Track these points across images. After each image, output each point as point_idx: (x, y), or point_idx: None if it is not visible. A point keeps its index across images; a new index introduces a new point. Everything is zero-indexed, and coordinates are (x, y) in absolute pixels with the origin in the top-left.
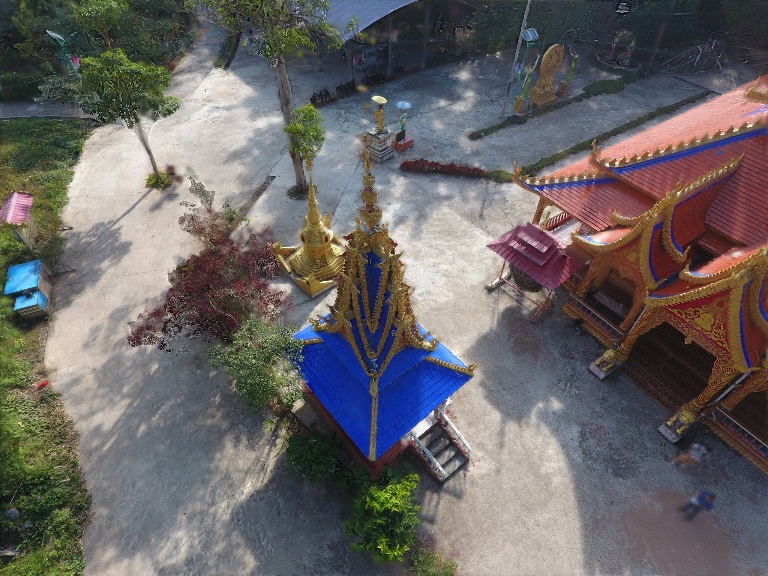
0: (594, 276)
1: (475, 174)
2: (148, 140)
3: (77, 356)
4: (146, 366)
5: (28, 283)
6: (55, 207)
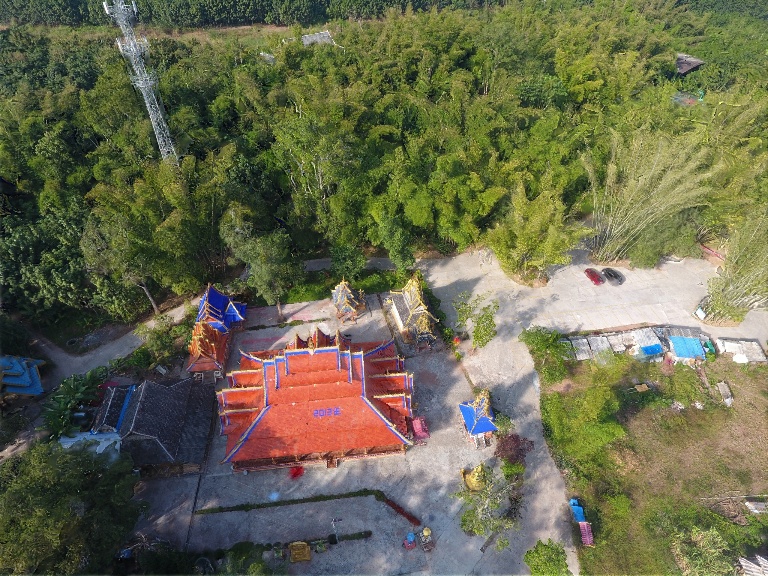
0: None
1: None
2: None
3: (555, 479)
4: (534, 466)
5: (576, 509)
6: (583, 570)
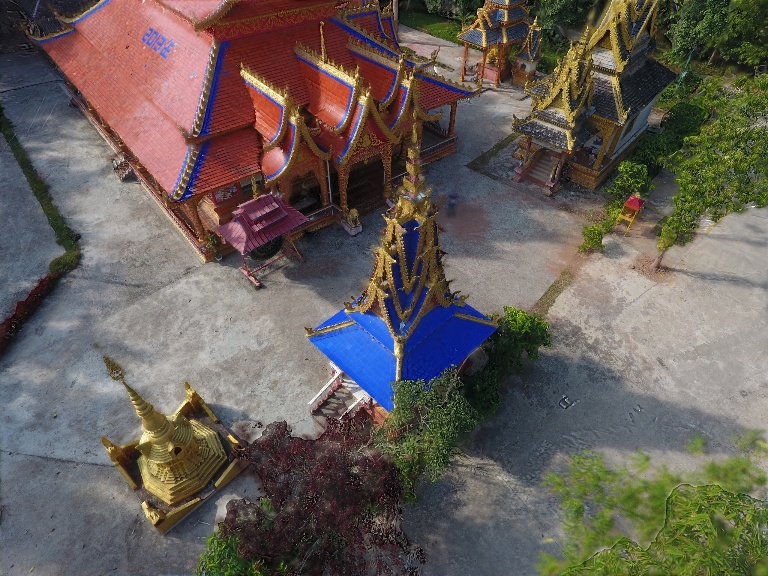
0: (288, 197)
1: (50, 285)
2: None
3: None
4: None
5: None
6: None
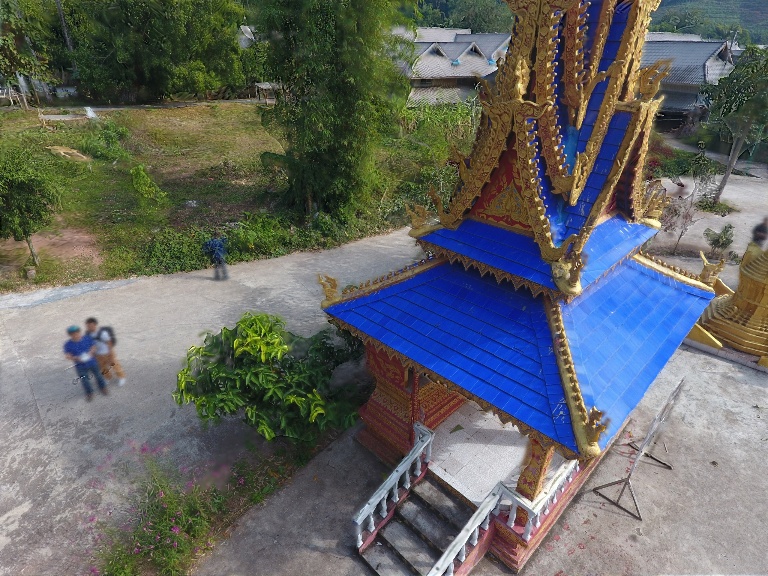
0: None
1: None
2: (765, 194)
3: None
4: None
5: None
6: None
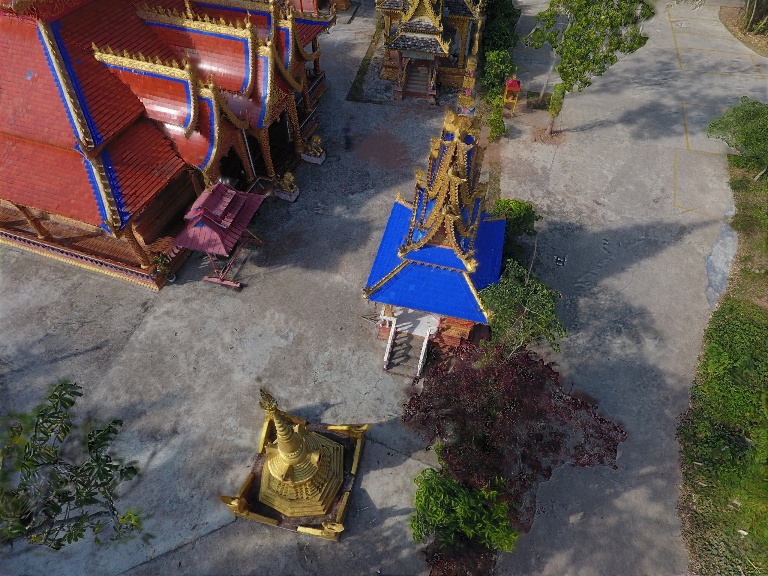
0: None
1: None
2: None
3: None
4: (583, 531)
5: None
6: None
